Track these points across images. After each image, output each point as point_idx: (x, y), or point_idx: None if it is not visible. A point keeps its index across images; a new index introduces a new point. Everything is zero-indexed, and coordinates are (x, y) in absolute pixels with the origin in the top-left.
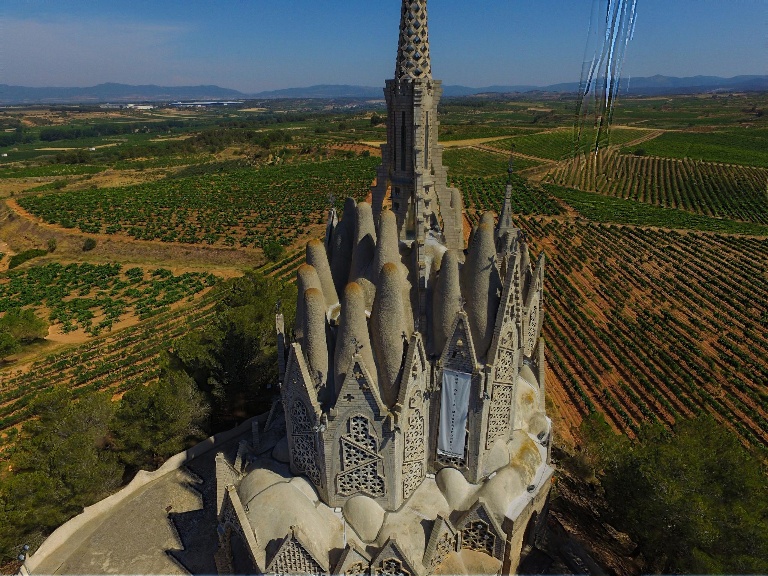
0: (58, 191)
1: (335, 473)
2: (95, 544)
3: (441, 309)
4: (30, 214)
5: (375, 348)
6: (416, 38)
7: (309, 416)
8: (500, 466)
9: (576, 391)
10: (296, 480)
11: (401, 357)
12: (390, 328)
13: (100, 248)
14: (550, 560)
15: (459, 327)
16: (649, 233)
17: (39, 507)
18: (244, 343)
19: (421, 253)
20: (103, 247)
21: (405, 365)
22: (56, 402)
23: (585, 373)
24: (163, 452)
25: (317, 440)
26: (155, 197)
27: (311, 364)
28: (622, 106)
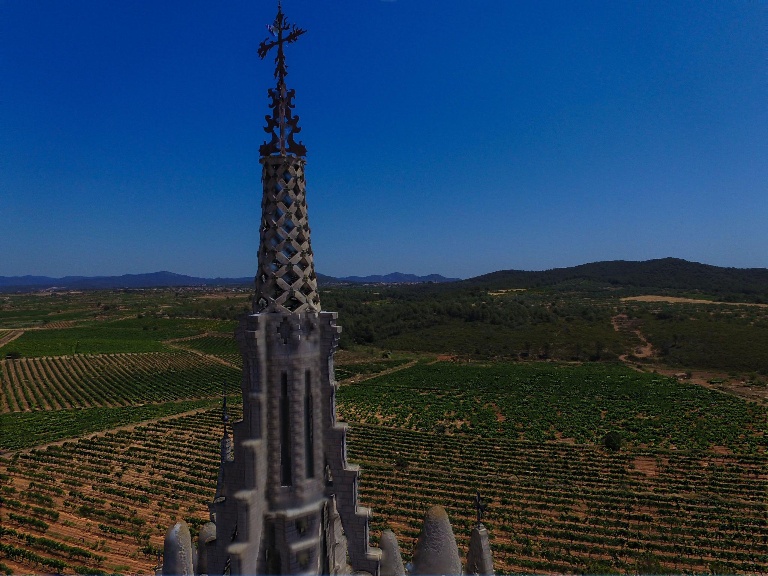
0: None
1: None
2: None
3: None
4: None
5: None
6: (307, 247)
7: None
8: None
9: None
10: None
11: None
12: None
13: None
14: None
15: None
16: (97, 441)
17: None
18: None
19: None
20: None
21: None
22: None
23: None
24: None
25: None
26: None
27: None
28: None
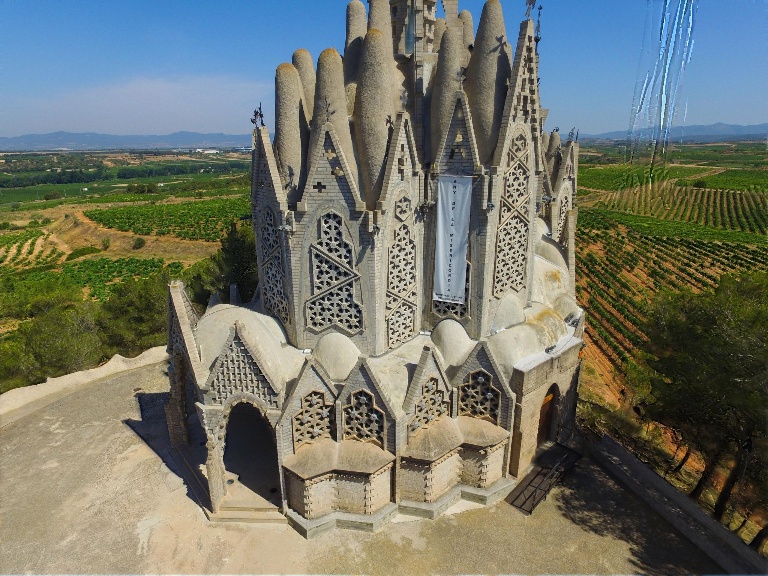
0: (121, 206)
1: (304, 299)
2: (50, 411)
3: (438, 103)
4: (92, 221)
5: (356, 142)
6: None
7: (276, 225)
8: (512, 323)
9: (623, 362)
10: (261, 314)
11: (385, 145)
12: (373, 108)
13: (148, 247)
14: (577, 455)
15: (458, 115)
16: None
17: (6, 380)
18: (244, 248)
19: (418, 50)
20: (151, 246)
21: (389, 152)
22: (53, 305)
23: (635, 349)
24: (145, 345)
25: (284, 255)
26: (206, 210)
27: (281, 158)
28: (679, 134)
